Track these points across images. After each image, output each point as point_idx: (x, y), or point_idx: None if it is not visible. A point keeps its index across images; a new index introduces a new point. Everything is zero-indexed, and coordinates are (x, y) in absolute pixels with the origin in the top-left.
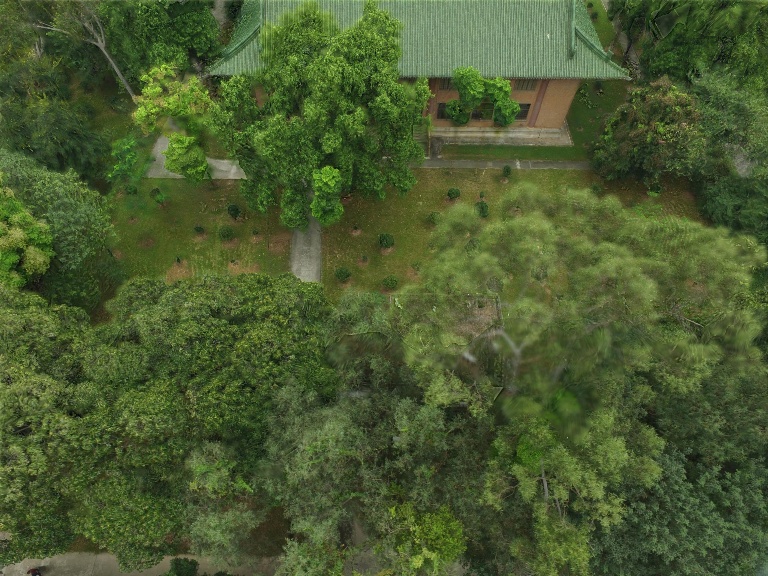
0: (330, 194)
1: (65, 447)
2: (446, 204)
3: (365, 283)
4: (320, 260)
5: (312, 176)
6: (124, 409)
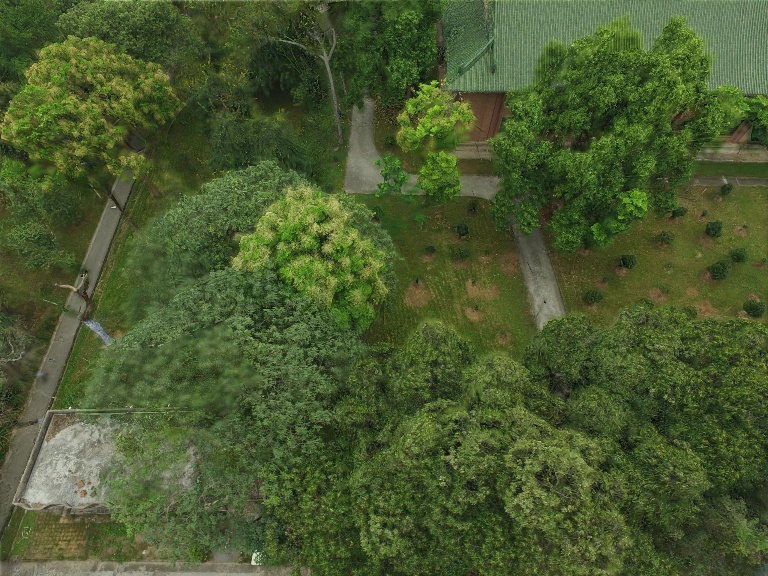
0: (636, 218)
1: (620, 508)
2: (667, 223)
3: (611, 305)
4: (556, 281)
5: (622, 200)
6: (657, 464)
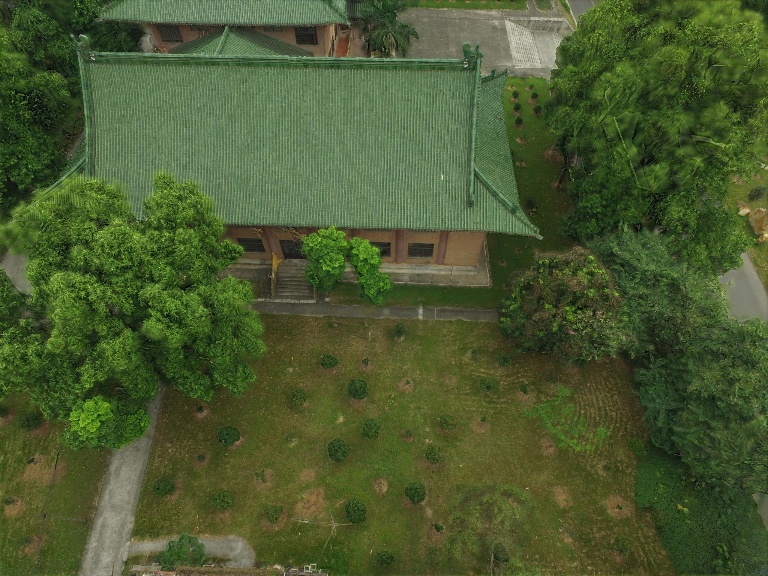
0: (96, 436)
1: None
2: (322, 371)
3: (196, 494)
4: (148, 455)
5: None
6: None
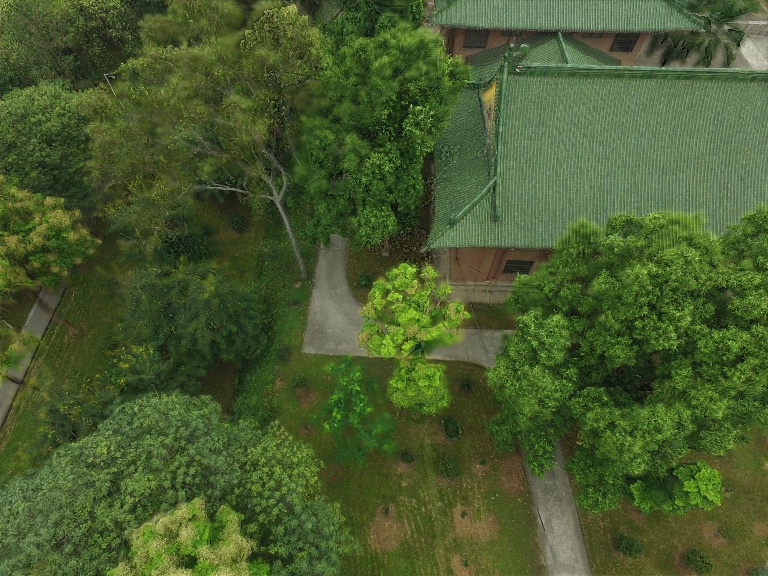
0: None
1: None
2: None
3: (650, 552)
4: (575, 506)
5: (682, 484)
6: None
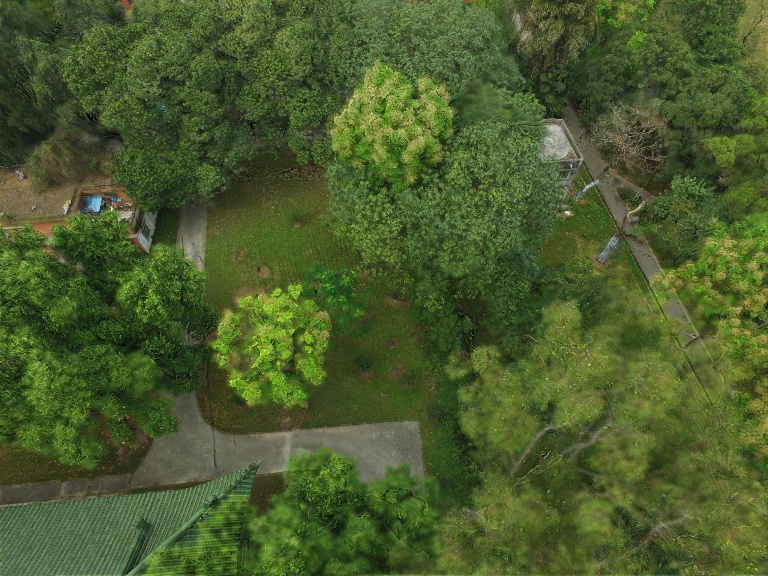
0: None
1: None
2: None
3: None
4: None
5: None
6: None
